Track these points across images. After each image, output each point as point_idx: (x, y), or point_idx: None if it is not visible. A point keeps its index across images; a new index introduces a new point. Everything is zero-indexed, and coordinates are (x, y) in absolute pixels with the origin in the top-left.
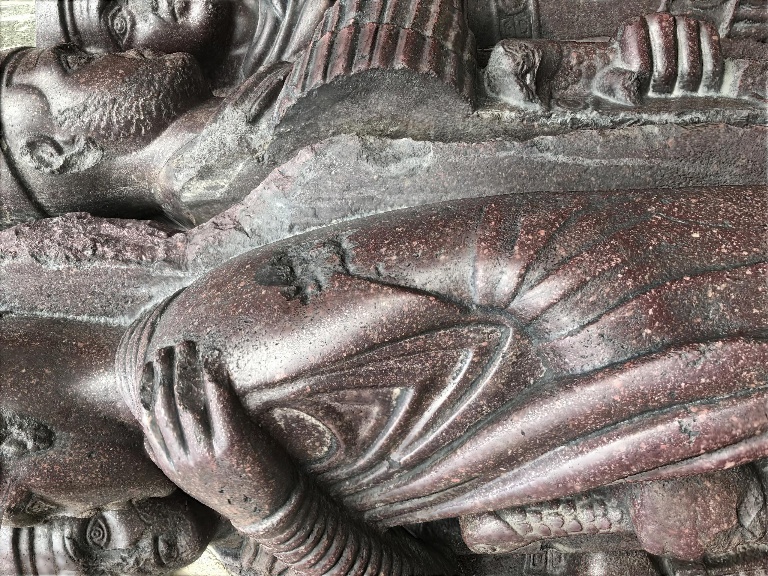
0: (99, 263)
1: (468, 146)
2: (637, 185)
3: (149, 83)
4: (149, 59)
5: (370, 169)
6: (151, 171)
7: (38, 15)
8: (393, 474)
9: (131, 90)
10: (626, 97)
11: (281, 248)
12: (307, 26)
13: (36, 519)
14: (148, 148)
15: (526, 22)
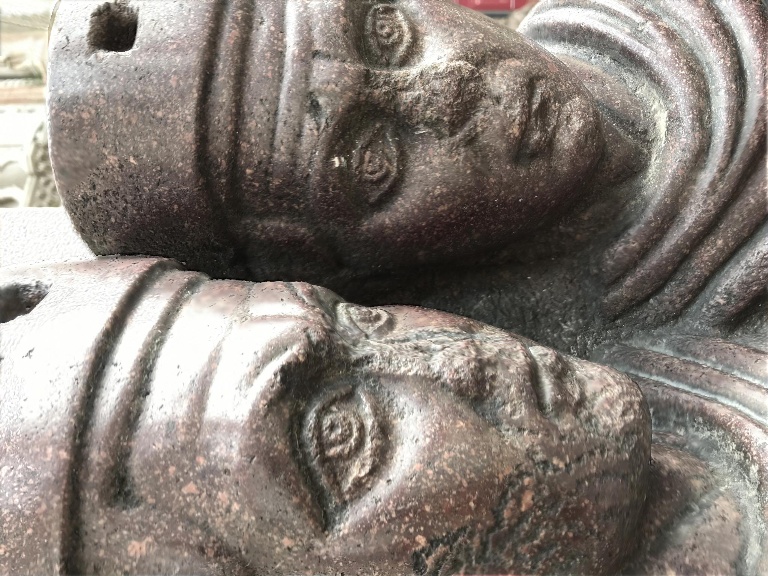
0: None
1: None
2: None
3: None
4: None
5: None
6: None
7: None
8: None
9: None
10: None
11: None
12: None
13: (359, 57)
14: None
15: None
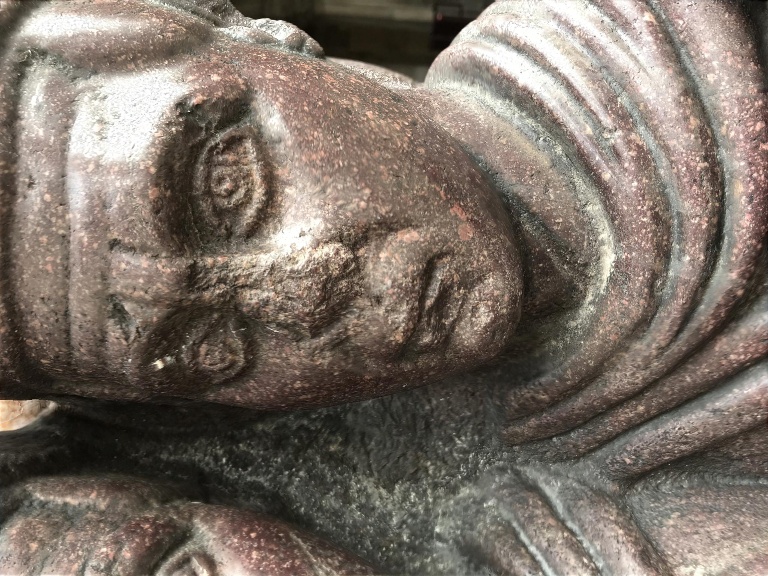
0: None
1: None
2: None
3: None
4: None
5: None
6: None
7: None
8: None
9: None
10: None
11: None
12: None
13: (182, 240)
14: None
15: None
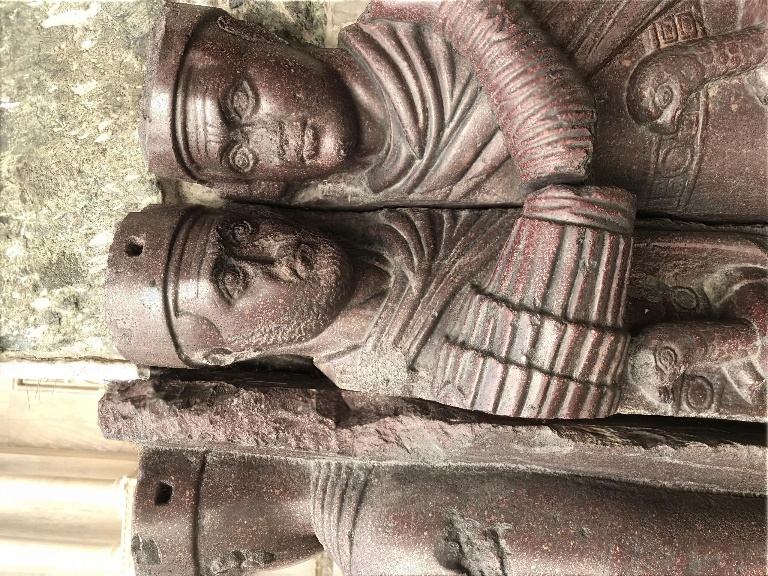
0: (284, 448)
1: (604, 448)
2: (728, 480)
3: (308, 309)
4: (304, 280)
5: (519, 448)
6: (309, 354)
7: (150, 150)
8: None
9: (293, 318)
10: (748, 395)
11: (448, 515)
12: (447, 175)
13: None
14: (306, 343)
15: (680, 185)
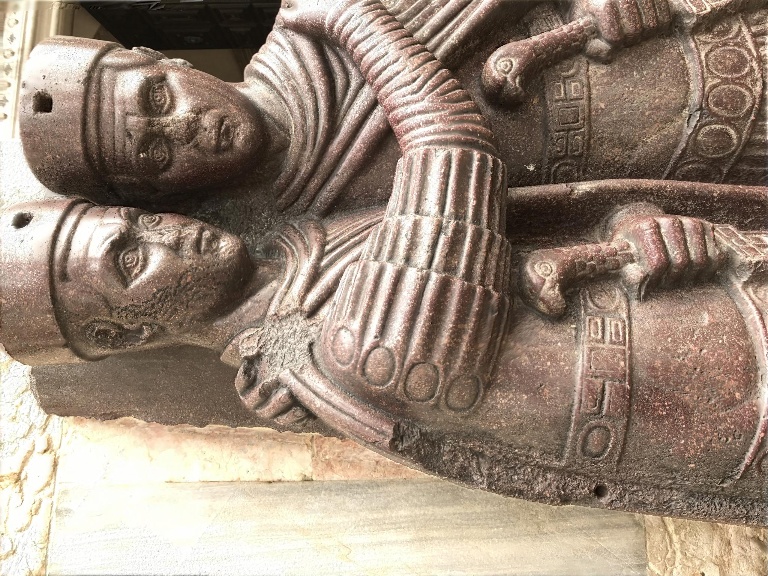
0: None
1: None
2: None
3: None
4: None
5: None
6: None
7: None
8: (434, 9)
9: None
10: None
11: None
12: None
13: (146, 112)
14: None
15: None
